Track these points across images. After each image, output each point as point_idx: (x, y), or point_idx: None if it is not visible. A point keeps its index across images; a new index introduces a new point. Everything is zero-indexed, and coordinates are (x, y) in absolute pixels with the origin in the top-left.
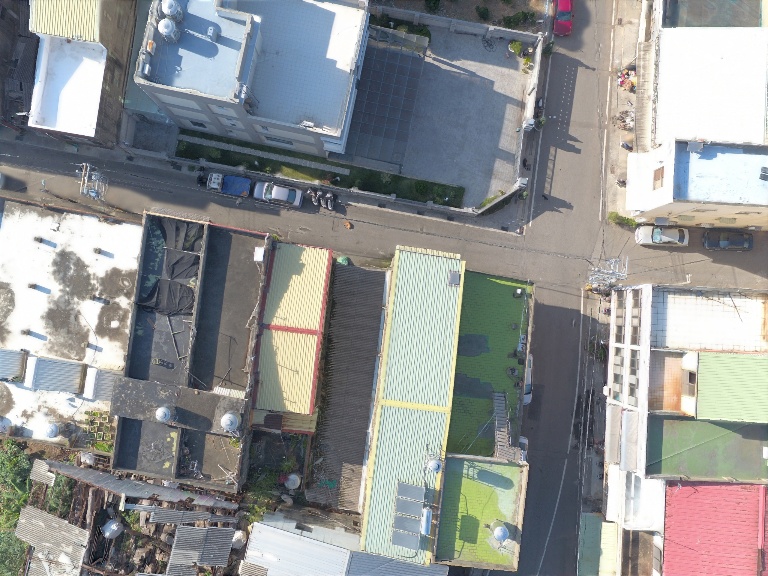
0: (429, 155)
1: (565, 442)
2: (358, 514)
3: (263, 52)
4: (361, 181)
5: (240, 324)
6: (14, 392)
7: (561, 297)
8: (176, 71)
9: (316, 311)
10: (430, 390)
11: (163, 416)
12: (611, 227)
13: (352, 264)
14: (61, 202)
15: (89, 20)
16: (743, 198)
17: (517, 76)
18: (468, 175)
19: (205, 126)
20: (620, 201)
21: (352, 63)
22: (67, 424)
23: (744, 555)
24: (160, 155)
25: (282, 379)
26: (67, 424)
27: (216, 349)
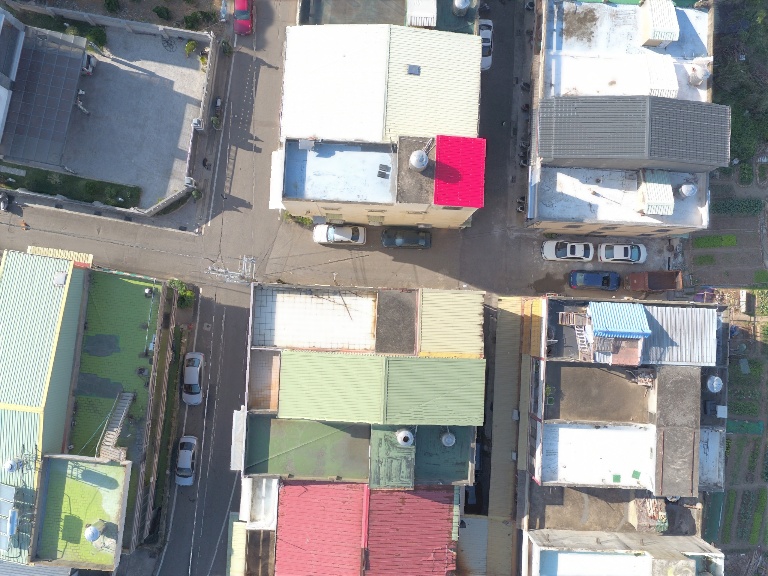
0: (107, 155)
1: None
2: None
3: None
4: (34, 182)
5: None
6: None
7: (238, 296)
8: None
9: None
10: (24, 390)
11: None
12: (290, 226)
13: None
14: None
15: None
16: (361, 196)
17: (198, 76)
18: (146, 175)
19: None
20: None
21: None
22: None
23: (348, 554)
24: None
25: None
26: None
27: None
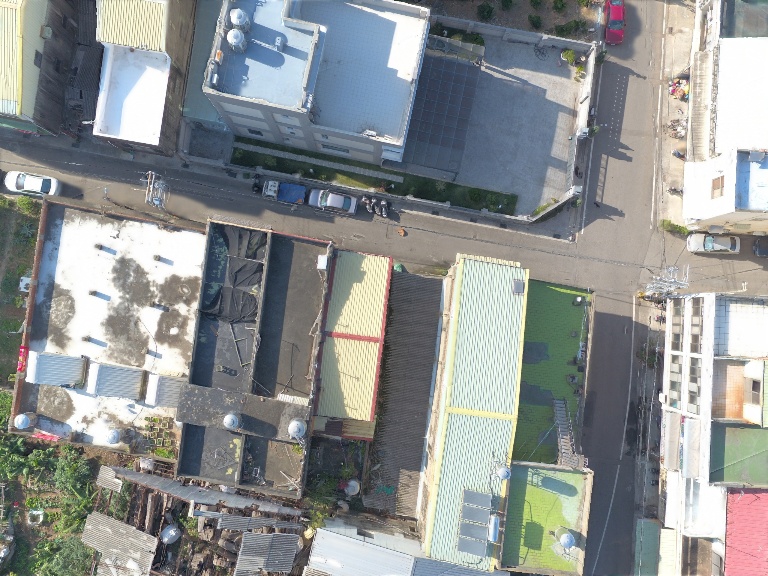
0: (482, 163)
1: (617, 448)
2: (413, 520)
3: (325, 61)
4: (415, 189)
5: (302, 331)
6: (74, 398)
7: (613, 304)
8: (243, 81)
9: (378, 319)
10: (496, 398)
11: (231, 423)
12: (662, 235)
13: (406, 271)
14: (121, 209)
15: (156, 30)
16: None
17: (569, 84)
18: (521, 183)
19: (262, 134)
20: (671, 209)
21: (414, 72)
22: (127, 430)
23: None
24: (217, 163)
25: (344, 386)
26: (127, 430)
27: (278, 356)
